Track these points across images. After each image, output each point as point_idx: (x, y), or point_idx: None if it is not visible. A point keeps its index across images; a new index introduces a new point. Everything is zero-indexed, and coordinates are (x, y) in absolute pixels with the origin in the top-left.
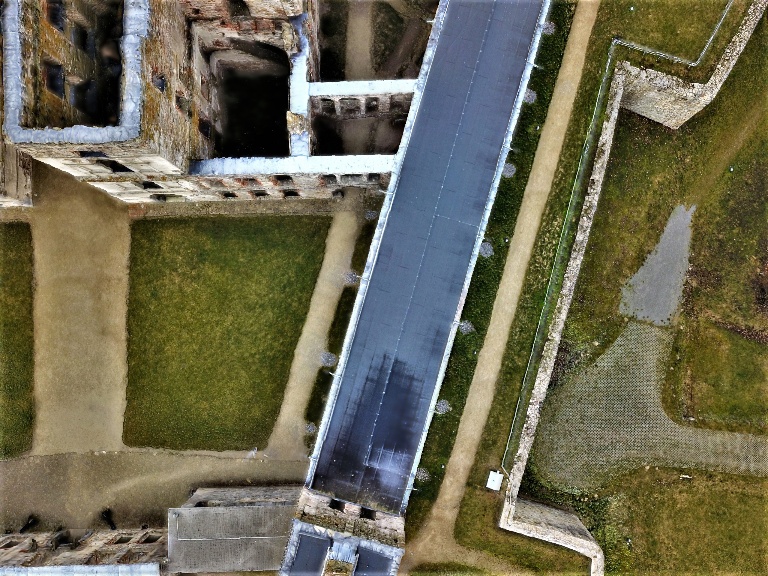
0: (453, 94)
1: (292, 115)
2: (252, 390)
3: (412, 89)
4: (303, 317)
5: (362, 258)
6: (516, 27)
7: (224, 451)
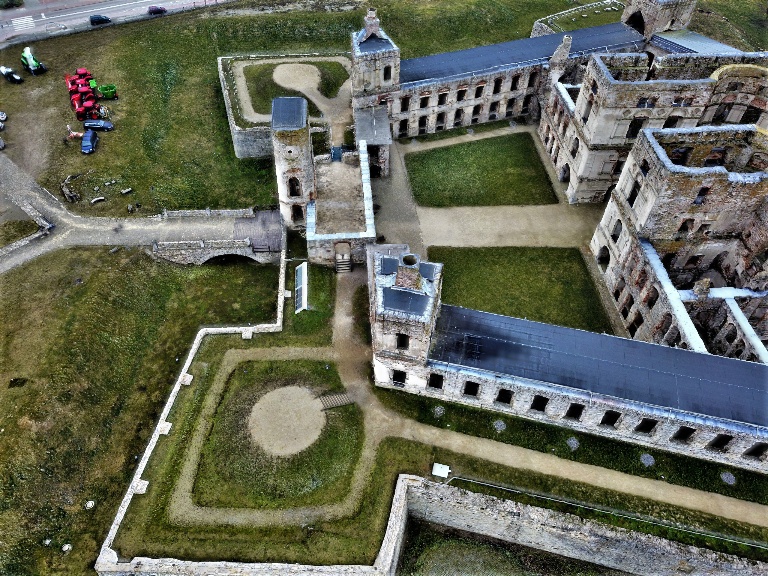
0: None
1: (708, 282)
2: None
3: (766, 362)
4: None
5: None
6: None
7: None
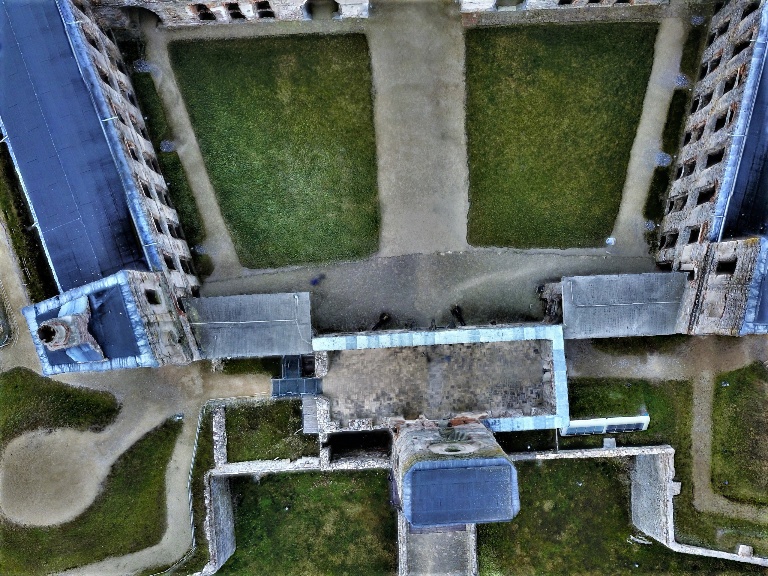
0: None
1: None
2: (591, 190)
3: None
4: (637, 119)
5: (691, 62)
6: None
7: (567, 249)
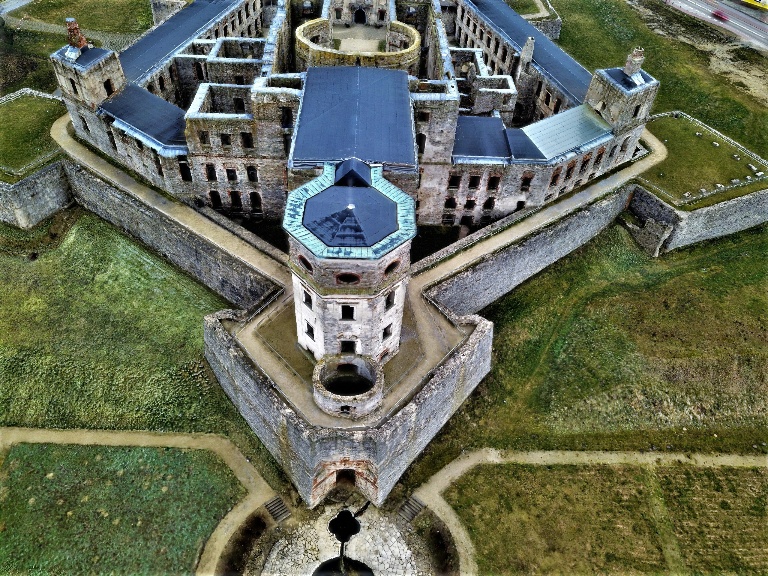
0: (159, 48)
1: None
2: None
3: None
4: None
5: None
6: (120, 60)
7: None
